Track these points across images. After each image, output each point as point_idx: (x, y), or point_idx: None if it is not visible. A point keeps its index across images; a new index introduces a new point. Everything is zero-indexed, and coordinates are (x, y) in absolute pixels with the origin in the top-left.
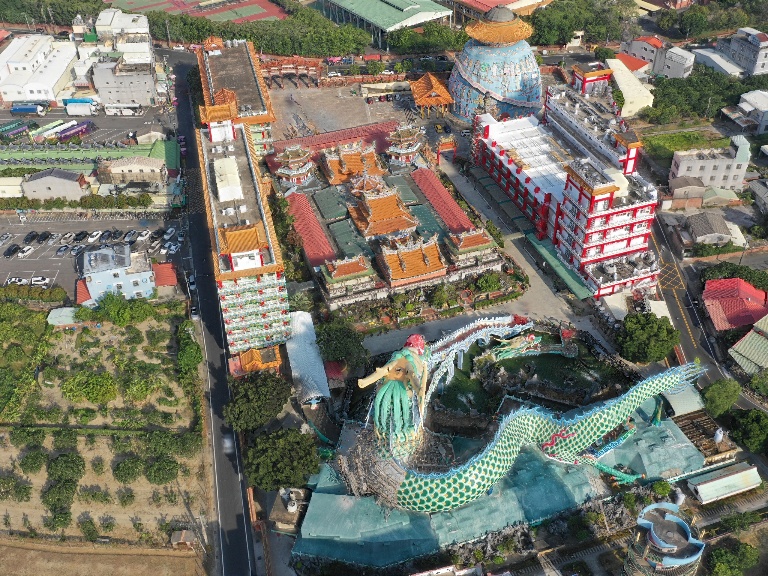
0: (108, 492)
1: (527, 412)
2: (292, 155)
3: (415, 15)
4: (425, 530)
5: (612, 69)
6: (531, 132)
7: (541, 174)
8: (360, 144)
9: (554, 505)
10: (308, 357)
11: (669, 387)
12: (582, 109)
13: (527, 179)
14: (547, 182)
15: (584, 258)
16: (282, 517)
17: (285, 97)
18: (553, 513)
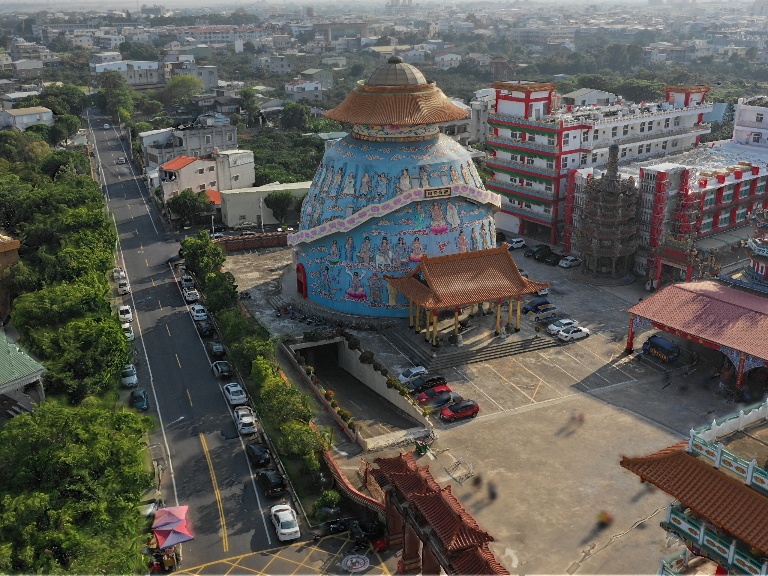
0: None
1: None
2: None
3: None
4: None
5: (272, 190)
6: None
7: None
8: None
9: None
10: None
11: None
12: None
13: None
14: None
15: None
16: None
17: None
18: None
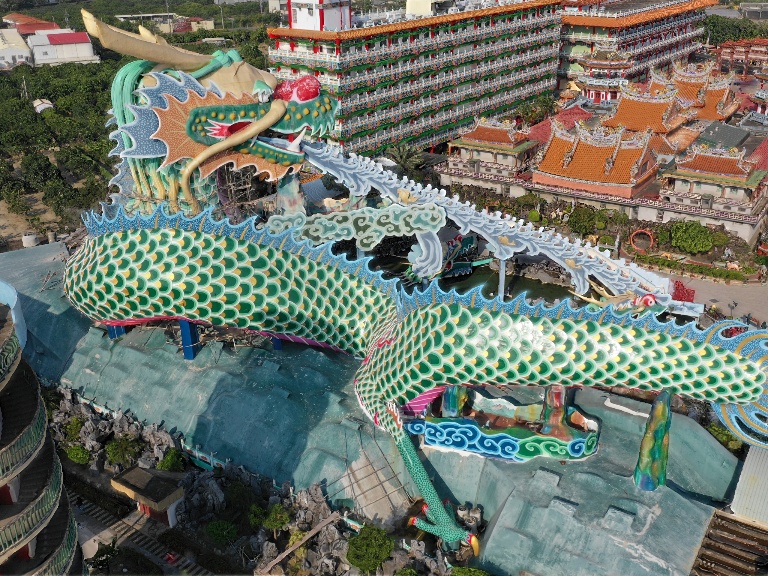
0: (33, 206)
1: (381, 283)
2: (599, 56)
3: None
4: (65, 340)
5: None
6: None
7: None
8: (708, 70)
9: (253, 451)
10: (319, 183)
11: (713, 384)
12: None
13: None
14: None
15: None
16: (15, 248)
17: (733, 84)
18: (239, 464)
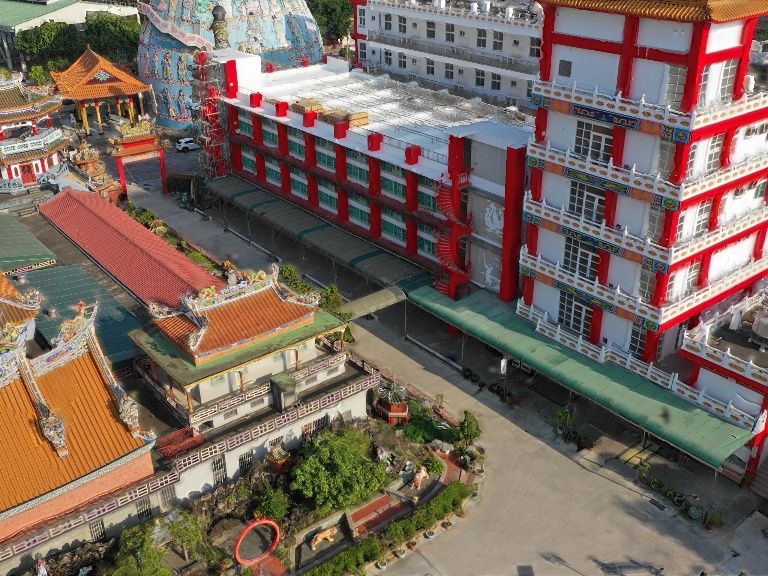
0: None
1: None
2: None
3: (68, 7)
4: None
5: None
6: (338, 81)
7: (404, 128)
8: None
9: None
10: None
11: None
12: (450, 5)
13: (373, 137)
14: (429, 140)
15: (666, 307)
16: None
17: None
18: None
